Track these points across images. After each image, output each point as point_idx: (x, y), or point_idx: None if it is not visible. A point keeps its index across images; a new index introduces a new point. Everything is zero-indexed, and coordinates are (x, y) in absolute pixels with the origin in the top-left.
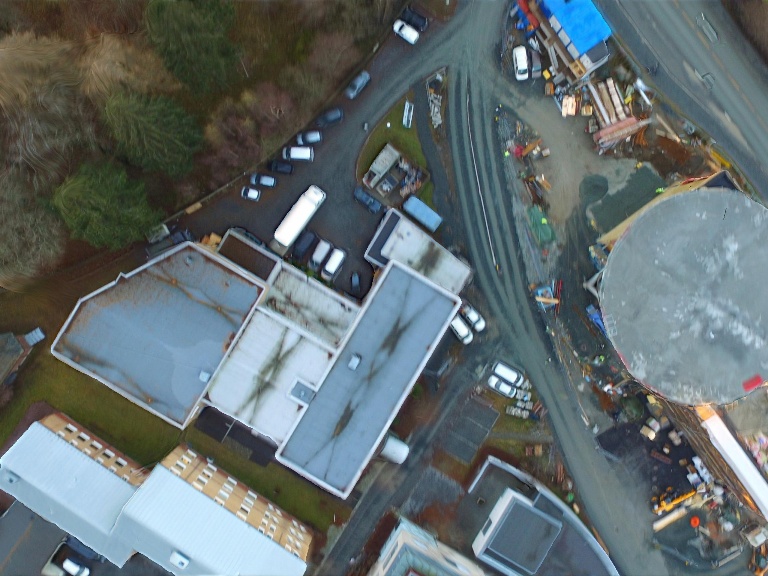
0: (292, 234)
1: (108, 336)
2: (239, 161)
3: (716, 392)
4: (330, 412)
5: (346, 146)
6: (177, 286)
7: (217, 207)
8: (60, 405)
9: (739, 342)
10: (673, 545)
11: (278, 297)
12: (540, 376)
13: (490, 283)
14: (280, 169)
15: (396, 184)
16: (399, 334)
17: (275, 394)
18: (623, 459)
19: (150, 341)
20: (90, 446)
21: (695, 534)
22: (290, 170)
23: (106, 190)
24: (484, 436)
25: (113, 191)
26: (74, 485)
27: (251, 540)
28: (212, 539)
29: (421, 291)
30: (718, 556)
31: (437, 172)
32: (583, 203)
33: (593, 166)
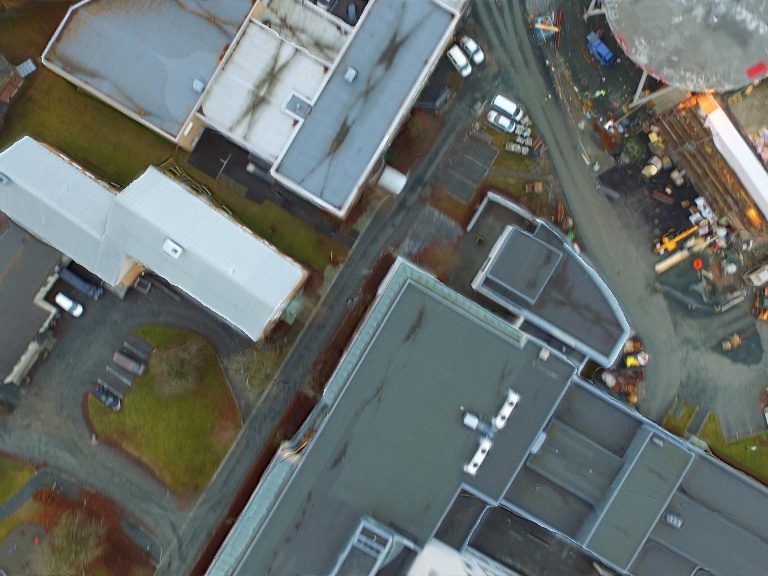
0: None
1: (100, 46)
2: None
3: (719, 79)
4: (326, 128)
5: None
6: None
7: None
8: (52, 139)
9: (743, 27)
10: (675, 288)
11: (273, 20)
12: (540, 113)
13: (489, 15)
14: None
15: None
16: (396, 48)
17: (270, 109)
18: (624, 200)
19: (142, 51)
20: None
21: (698, 278)
22: None
23: None
24: (483, 174)
25: None
26: (66, 193)
27: (246, 243)
28: (206, 236)
29: (418, 3)
30: (721, 301)
31: None
32: None
33: None
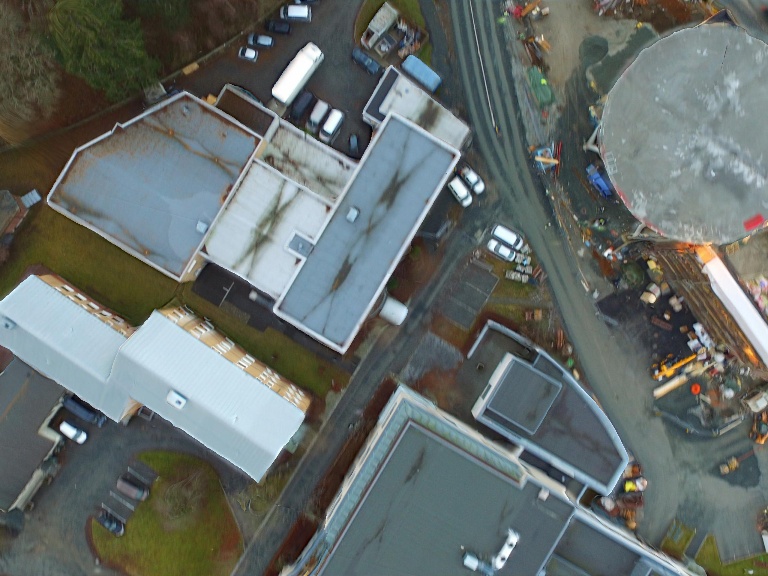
0: (290, 90)
1: (104, 187)
2: (236, 17)
3: (717, 231)
4: (328, 266)
5: (344, 6)
6: (174, 137)
7: (214, 68)
8: (57, 268)
9: (740, 181)
10: (674, 412)
11: (276, 154)
12: (540, 241)
13: (489, 145)
14: (278, 29)
15: (394, 44)
16: (398, 187)
17: (273, 247)
18: (623, 326)
19: (147, 192)
20: (87, 305)
21: (696, 402)
22: (288, 29)
23: (101, 14)
24: (483, 301)
25: (109, 17)
26: (70, 335)
27: (249, 387)
28: (209, 383)
29: (420, 143)
30: (719, 424)
31: (436, 32)
32: (583, 65)
33: (593, 27)
